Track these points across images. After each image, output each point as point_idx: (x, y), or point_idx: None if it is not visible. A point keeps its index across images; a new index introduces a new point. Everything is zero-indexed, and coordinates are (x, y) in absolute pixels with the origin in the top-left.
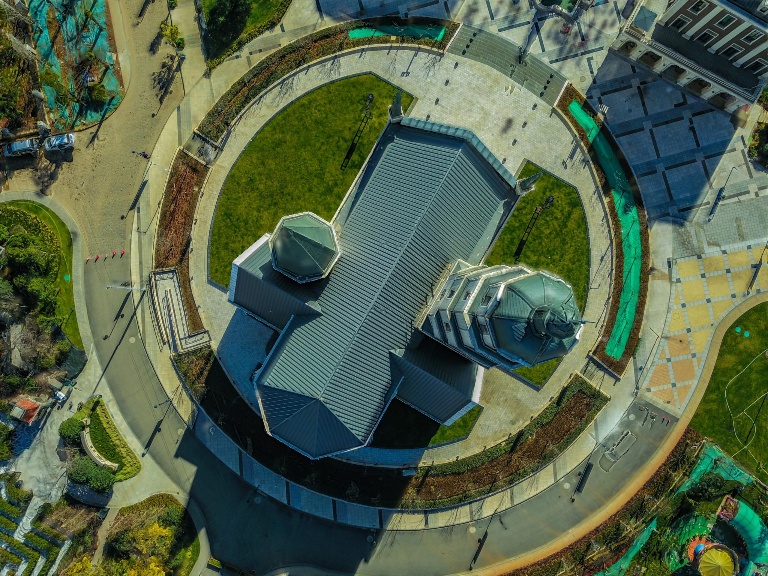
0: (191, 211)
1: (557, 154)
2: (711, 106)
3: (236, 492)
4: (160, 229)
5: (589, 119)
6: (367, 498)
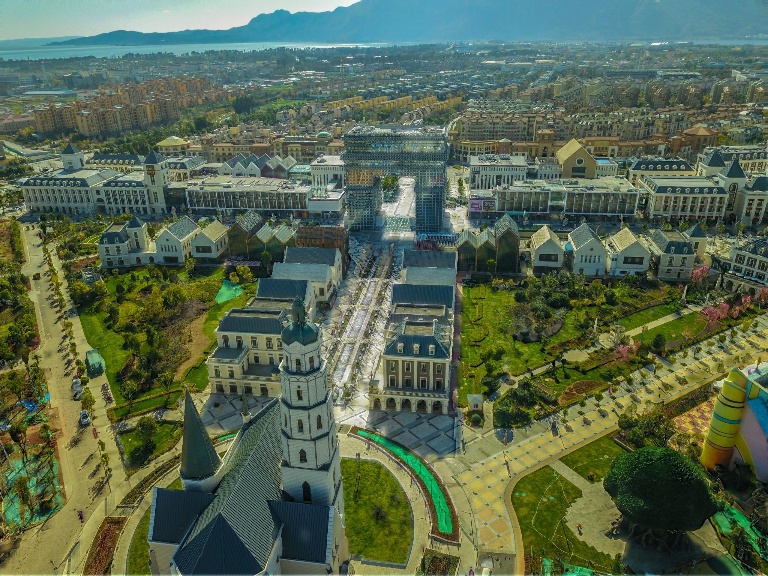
0: (114, 544)
1: (359, 451)
2: (435, 415)
3: None
4: (87, 564)
5: None
6: None
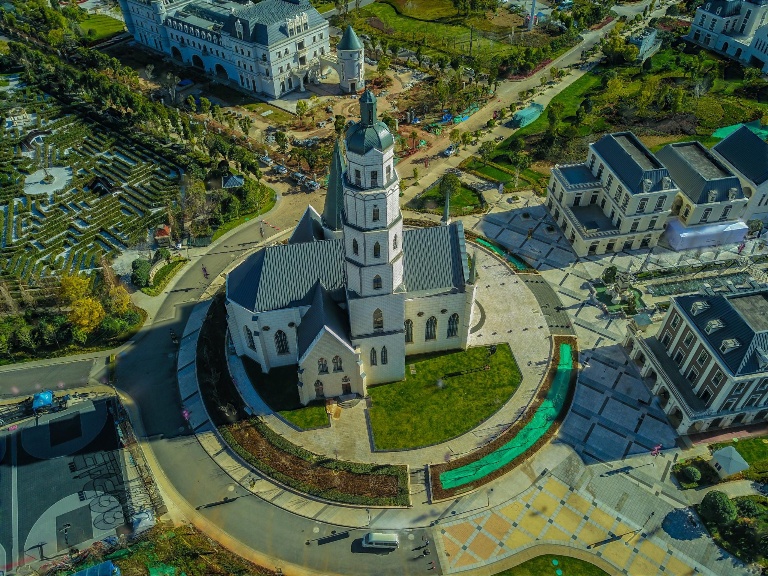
0: None
1: (530, 356)
2: (667, 421)
3: (170, 342)
4: None
5: (570, 359)
6: (212, 404)
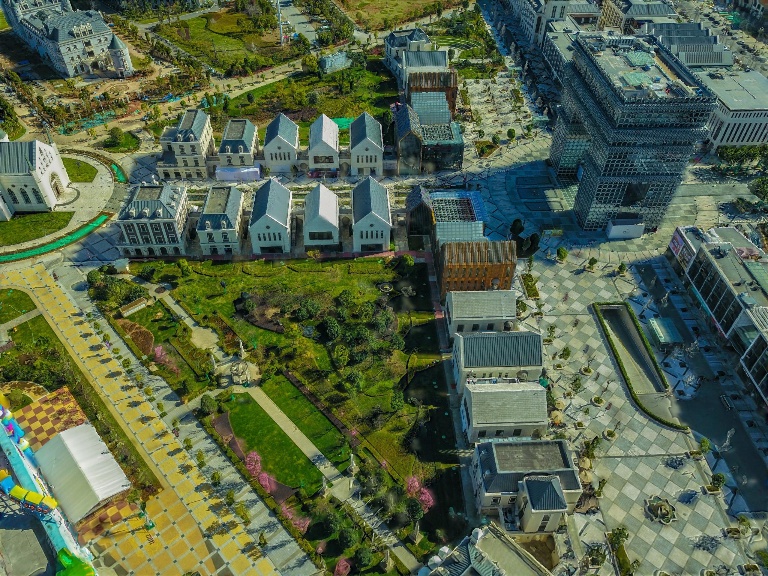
0: None
1: (81, 218)
2: None
3: None
4: None
5: (101, 222)
6: None
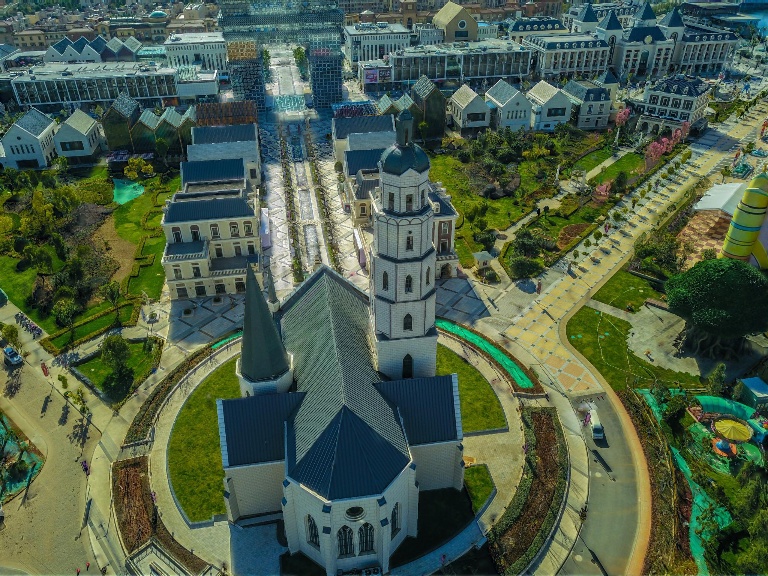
0: (146, 489)
1: None
2: (445, 279)
3: None
4: (121, 522)
5: None
6: None
